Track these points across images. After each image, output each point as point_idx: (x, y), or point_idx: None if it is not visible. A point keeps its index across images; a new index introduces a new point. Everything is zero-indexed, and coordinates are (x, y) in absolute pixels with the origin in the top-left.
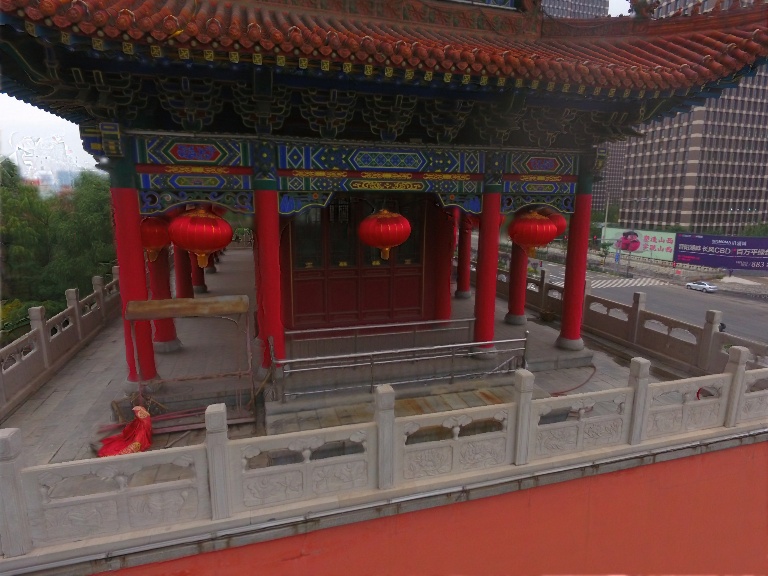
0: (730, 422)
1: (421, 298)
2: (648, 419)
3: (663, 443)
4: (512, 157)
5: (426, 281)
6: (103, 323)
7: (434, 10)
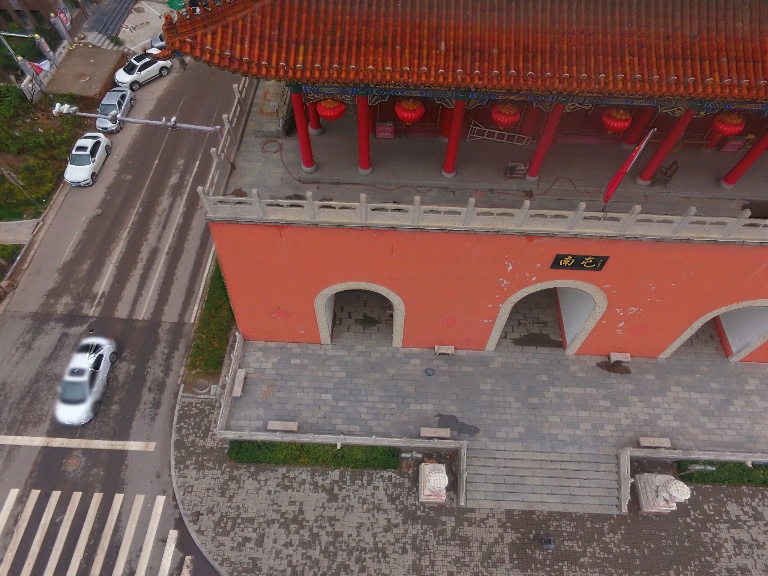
0: None
1: None
2: None
3: None
4: None
5: None
6: None
7: None
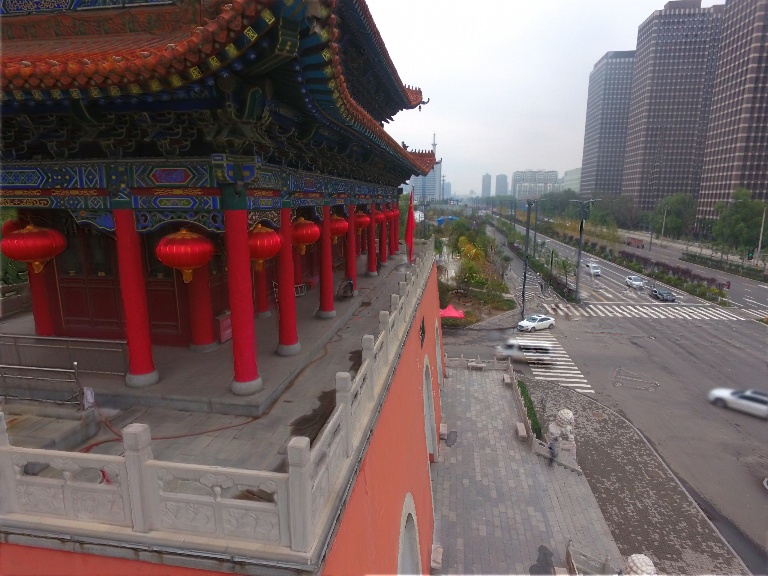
0: (136, 525)
1: (177, 314)
2: (16, 489)
3: (27, 523)
4: (134, 169)
5: (179, 297)
6: (23, 308)
7: (82, 21)
